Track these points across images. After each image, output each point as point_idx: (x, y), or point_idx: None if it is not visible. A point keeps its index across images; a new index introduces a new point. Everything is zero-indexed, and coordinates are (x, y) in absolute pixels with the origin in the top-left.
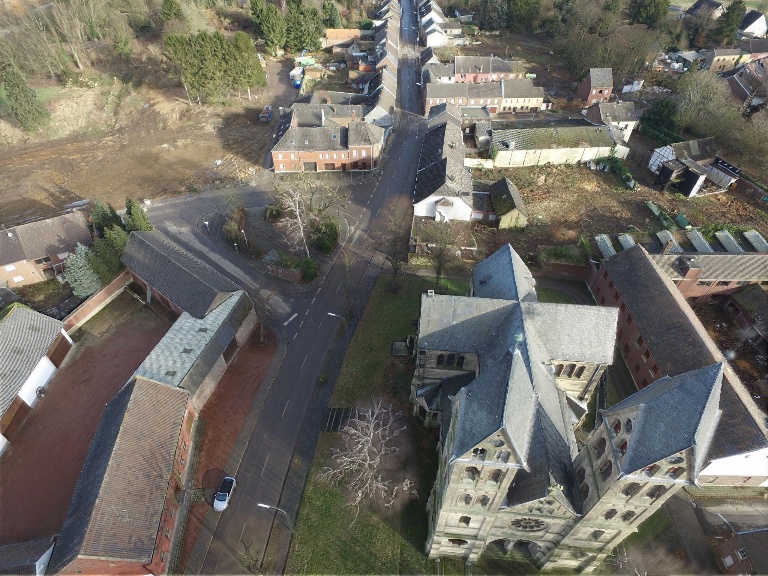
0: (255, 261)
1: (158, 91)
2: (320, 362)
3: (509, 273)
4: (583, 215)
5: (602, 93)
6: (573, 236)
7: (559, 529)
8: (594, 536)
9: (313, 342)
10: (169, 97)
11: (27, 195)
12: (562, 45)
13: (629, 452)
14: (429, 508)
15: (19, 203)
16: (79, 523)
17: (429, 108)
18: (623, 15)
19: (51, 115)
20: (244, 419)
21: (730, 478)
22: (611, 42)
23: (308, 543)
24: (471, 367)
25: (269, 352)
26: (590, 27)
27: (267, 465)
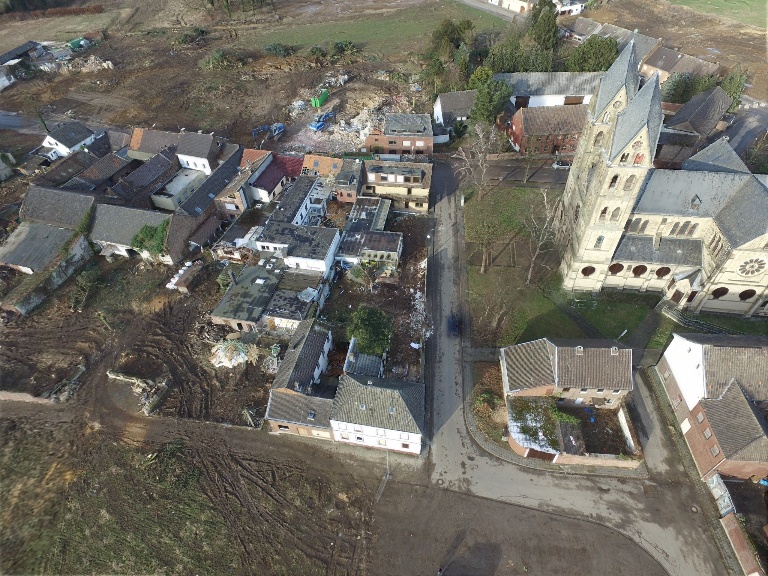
0: None
1: None
2: None
3: None
4: None
5: None
6: None
7: None
8: None
9: None
10: None
11: None
12: None
13: None
14: None
15: (722, 68)
16: None
17: None
18: None
19: None
20: None
21: None
22: None
23: None
24: None
25: None
26: None
27: None
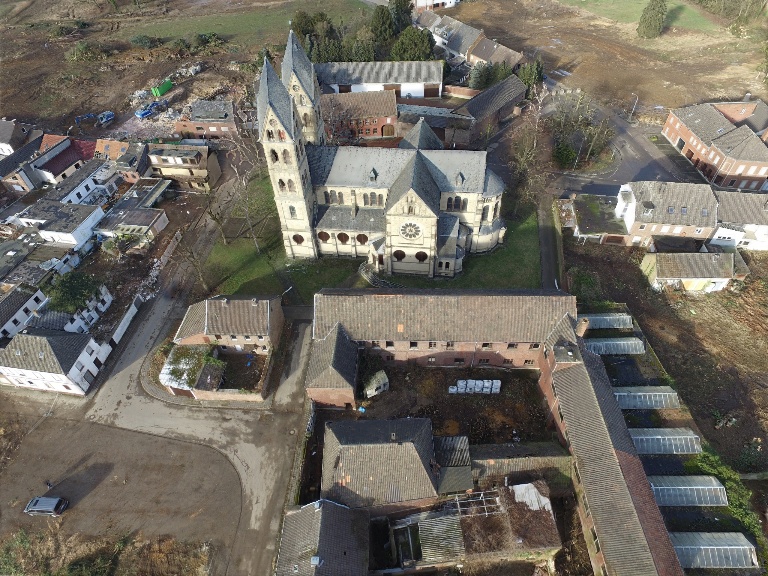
0: None
1: None
2: None
3: None
4: (731, 363)
5: None
6: (663, 337)
7: None
8: None
9: None
10: None
11: (564, 57)
12: None
13: None
14: None
15: (554, 57)
16: None
17: None
18: None
19: (672, 37)
20: None
21: None
22: None
23: None
24: None
25: None
26: None
27: None
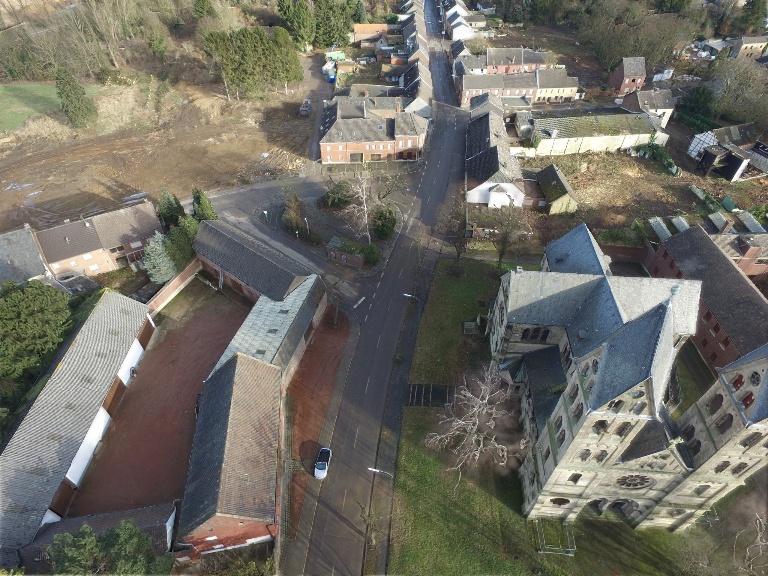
0: (316, 248)
1: (195, 87)
2: (394, 342)
3: (589, 250)
4: (629, 200)
5: (635, 82)
6: (622, 220)
7: (664, 485)
8: (697, 492)
9: (384, 323)
10: (207, 93)
11: (85, 189)
12: (588, 36)
13: (758, 402)
14: (523, 473)
15: (79, 197)
16: (206, 486)
17: (465, 99)
18: (649, 5)
19: None
20: (330, 395)
21: None
22: (642, 31)
23: (409, 507)
24: (555, 341)
25: (344, 333)
26: (617, 17)
27: (358, 437)
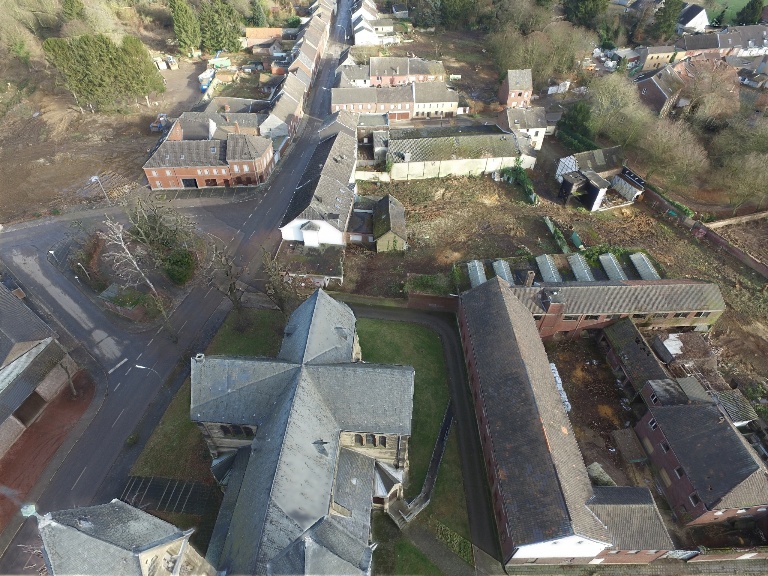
0: None
1: (52, 98)
2: (136, 418)
3: (307, 327)
4: (474, 234)
5: (522, 96)
6: (457, 259)
7: None
8: None
9: (135, 393)
10: (62, 105)
11: None
12: None
13: None
14: None
15: None
16: None
17: None
18: (557, 11)
19: None
20: (26, 493)
21: (552, 559)
22: (532, 41)
23: None
24: None
25: (81, 407)
26: (521, 24)
27: None
